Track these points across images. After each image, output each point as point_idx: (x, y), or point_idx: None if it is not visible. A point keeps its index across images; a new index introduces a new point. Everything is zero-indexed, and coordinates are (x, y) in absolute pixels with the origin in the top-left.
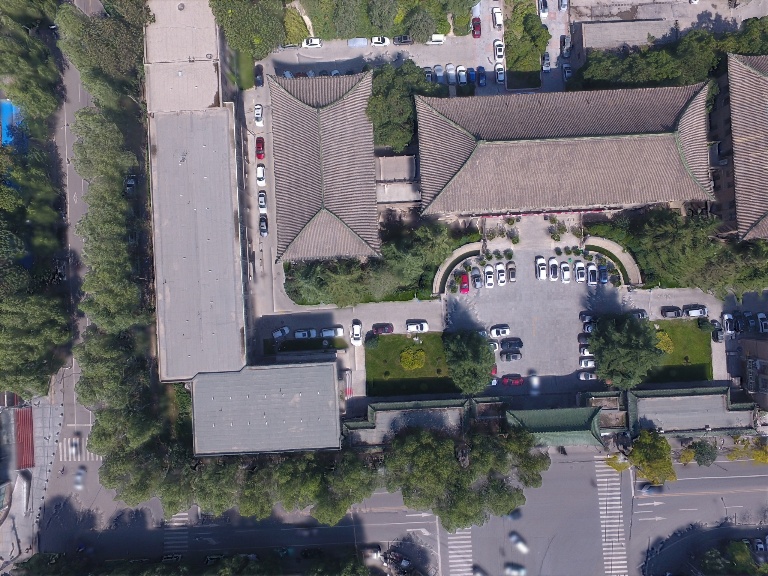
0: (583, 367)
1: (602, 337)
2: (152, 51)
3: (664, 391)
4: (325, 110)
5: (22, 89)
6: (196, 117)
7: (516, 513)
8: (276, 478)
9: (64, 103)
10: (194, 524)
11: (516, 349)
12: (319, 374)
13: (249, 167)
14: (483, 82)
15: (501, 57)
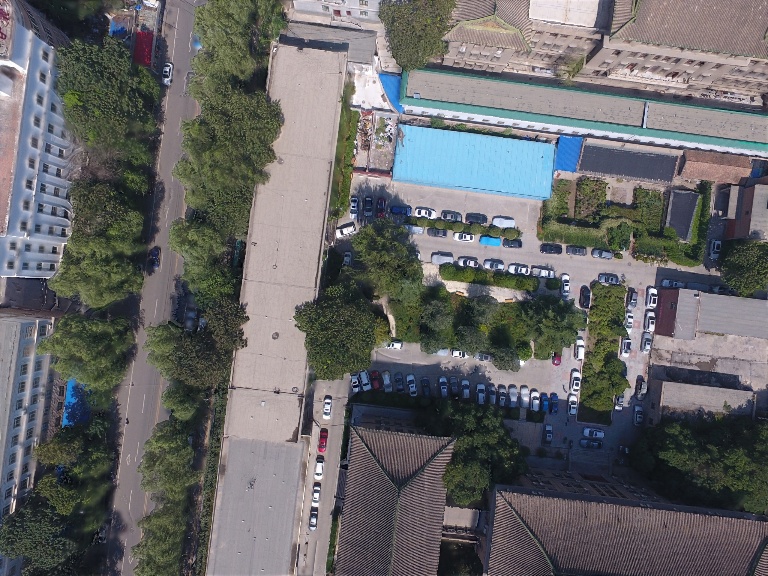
0: None
1: None
2: (238, 375)
3: None
4: (405, 487)
5: (98, 378)
6: (271, 444)
7: None
8: None
9: (133, 362)
10: None
11: None
12: None
13: (309, 459)
14: (555, 412)
15: (577, 391)
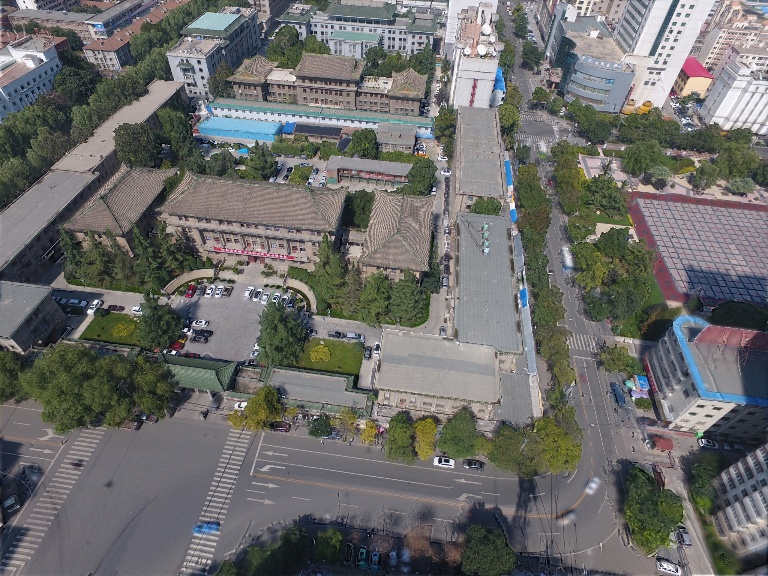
0: (252, 358)
1: None
2: (75, 151)
3: (298, 369)
4: (137, 170)
5: None
6: (75, 175)
7: (132, 466)
8: None
9: None
10: None
11: (205, 336)
12: (35, 292)
13: None
14: None
15: None
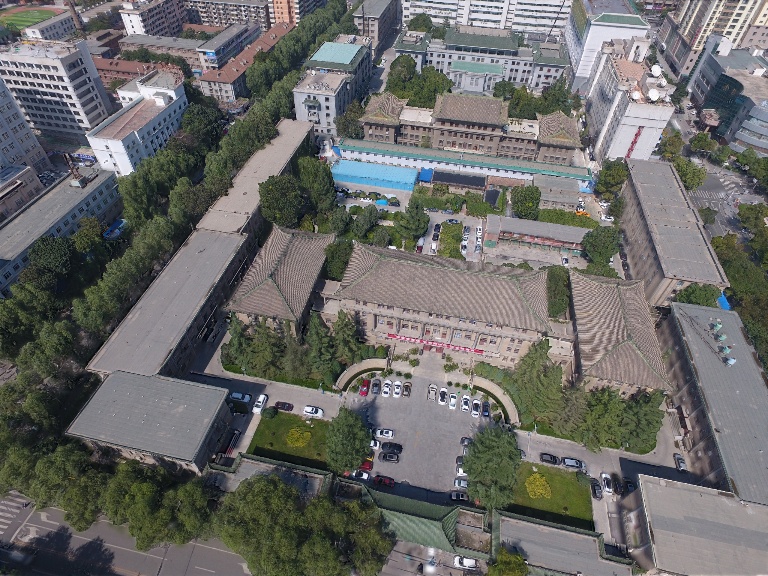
0: (457, 488)
1: (472, 449)
2: (217, 205)
3: (531, 518)
4: (298, 237)
5: (135, 210)
6: (222, 236)
7: None
8: (119, 468)
9: None
10: (0, 546)
11: (395, 452)
12: (210, 395)
13: None
14: None
15: None
